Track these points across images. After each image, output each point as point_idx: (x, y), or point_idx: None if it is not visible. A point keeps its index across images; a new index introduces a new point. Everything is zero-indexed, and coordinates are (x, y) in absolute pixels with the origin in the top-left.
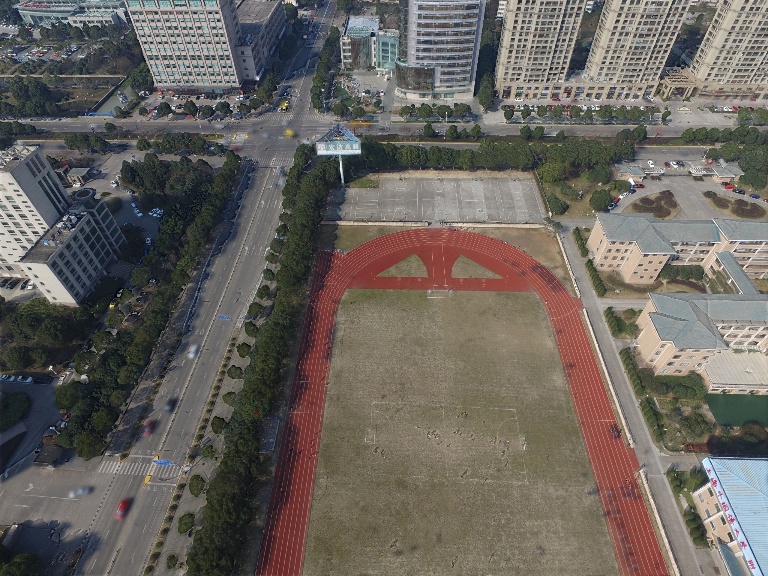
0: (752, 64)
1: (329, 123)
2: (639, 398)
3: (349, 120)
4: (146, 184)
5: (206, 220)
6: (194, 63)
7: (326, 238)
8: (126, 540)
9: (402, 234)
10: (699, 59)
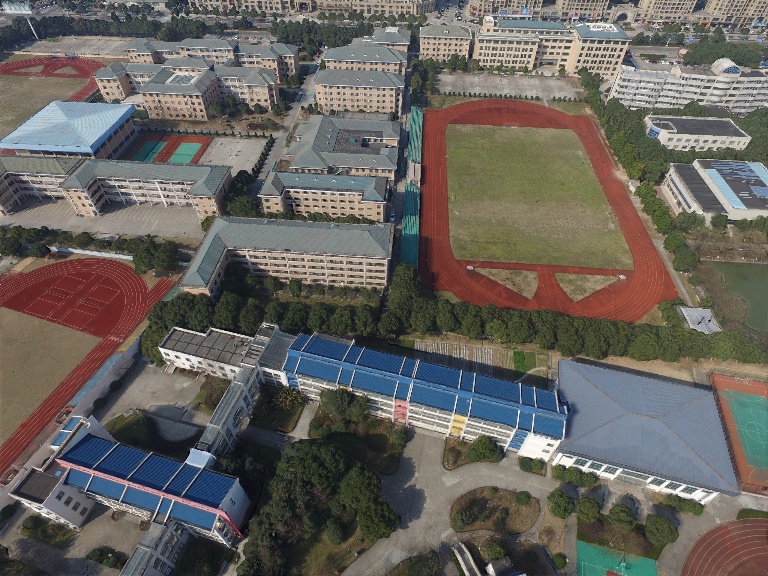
0: None
1: None
2: None
3: (79, 14)
4: None
5: None
6: None
7: (1, 58)
8: None
9: (46, 58)
10: None
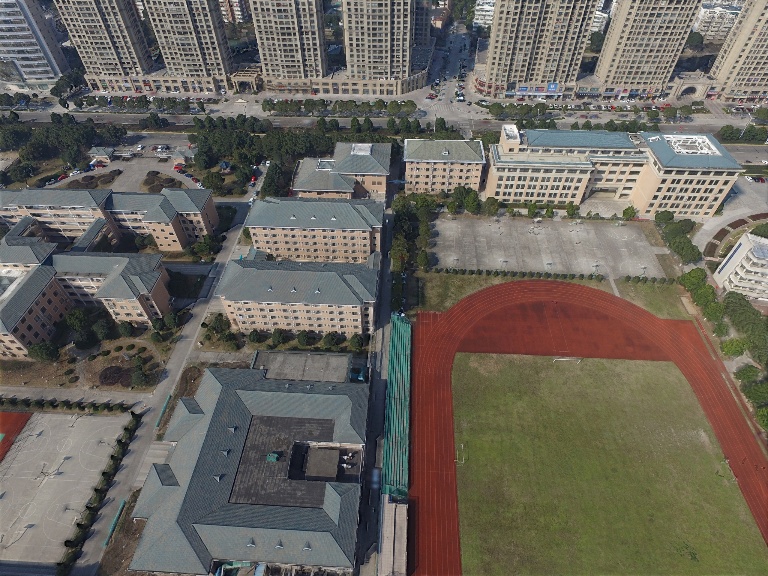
0: (295, 60)
1: None
2: None
3: None
4: None
5: None
6: None
7: None
8: None
9: None
10: None
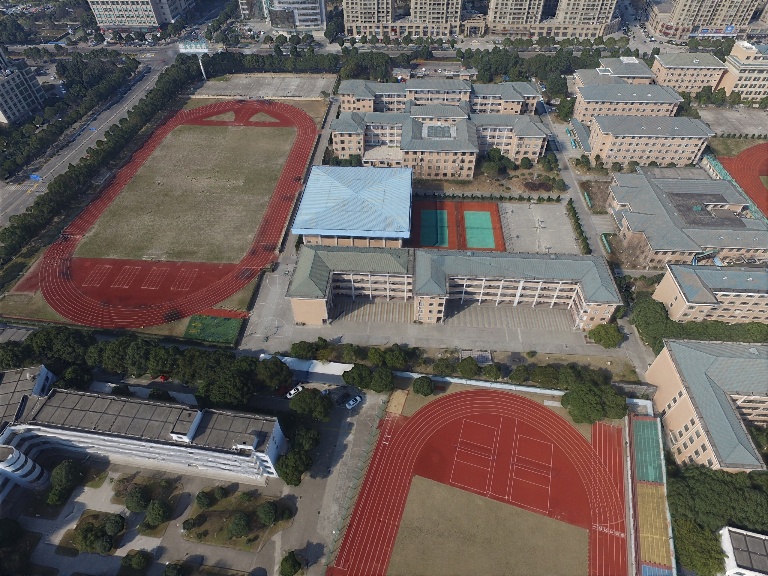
0: (522, 8)
1: (215, 49)
2: None
3: (230, 47)
4: (70, 73)
5: (101, 89)
6: (124, 8)
7: (180, 104)
8: (11, 209)
9: (230, 102)
10: (489, 6)
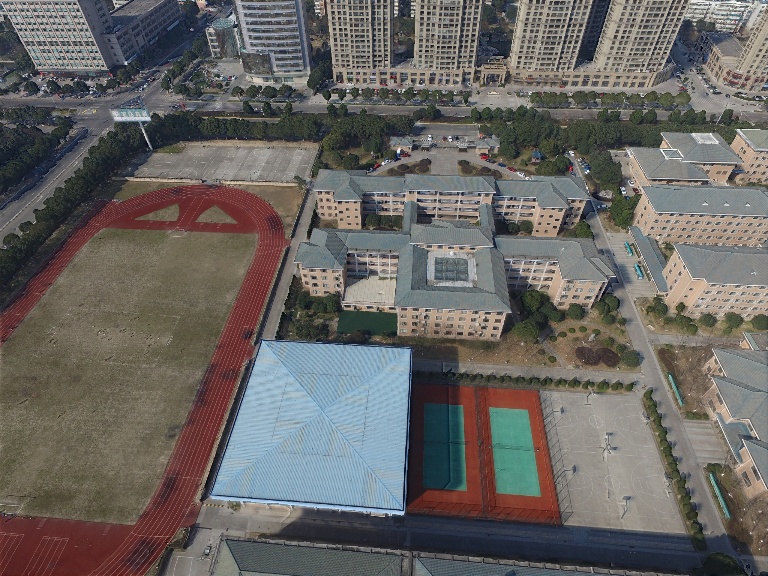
0: (553, 53)
1: (173, 101)
2: (285, 312)
3: (191, 99)
4: None
5: (7, 172)
6: (65, 48)
7: (111, 190)
8: None
9: (176, 189)
10: (512, 49)
